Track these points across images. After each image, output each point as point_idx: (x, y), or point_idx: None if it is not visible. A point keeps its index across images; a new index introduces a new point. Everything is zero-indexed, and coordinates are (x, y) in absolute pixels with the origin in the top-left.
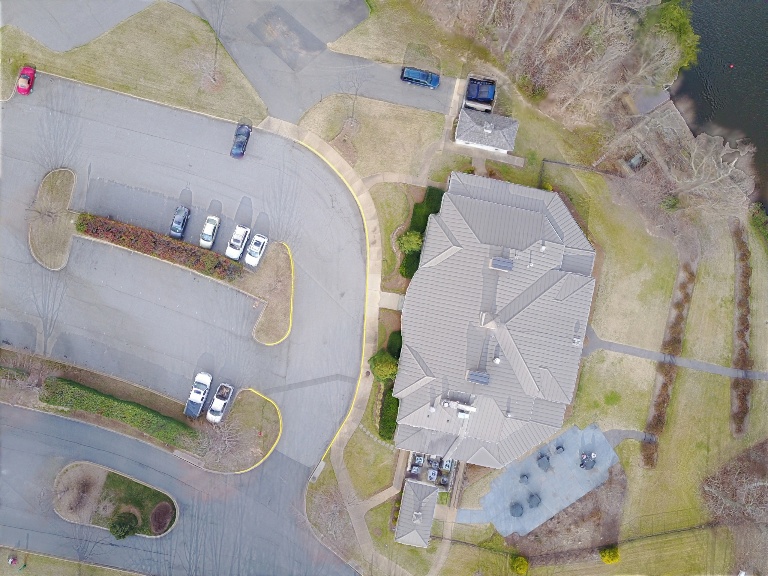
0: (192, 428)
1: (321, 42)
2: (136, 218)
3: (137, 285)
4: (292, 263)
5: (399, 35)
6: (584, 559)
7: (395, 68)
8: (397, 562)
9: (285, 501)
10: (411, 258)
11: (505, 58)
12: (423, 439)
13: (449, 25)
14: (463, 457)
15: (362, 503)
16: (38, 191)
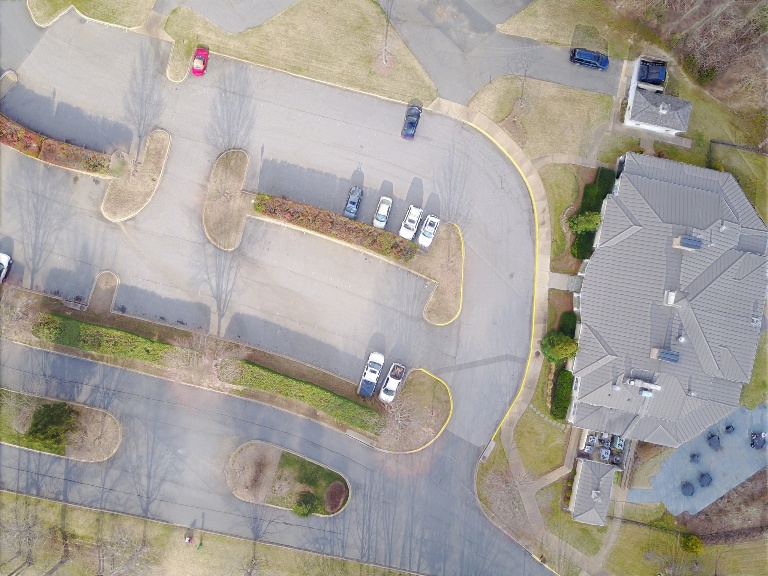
0: (367, 407)
1: (490, 23)
2: (309, 199)
3: (309, 265)
4: (462, 244)
5: (567, 17)
6: (754, 538)
7: (563, 50)
8: (567, 541)
9: (456, 480)
10: (583, 238)
11: (671, 40)
12: (601, 418)
13: (624, 6)
14: (641, 436)
15: (533, 482)
16: (212, 172)
